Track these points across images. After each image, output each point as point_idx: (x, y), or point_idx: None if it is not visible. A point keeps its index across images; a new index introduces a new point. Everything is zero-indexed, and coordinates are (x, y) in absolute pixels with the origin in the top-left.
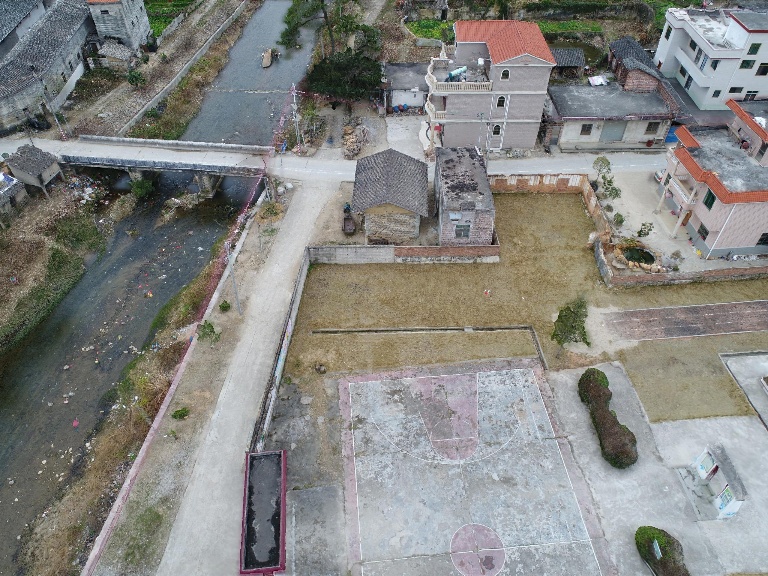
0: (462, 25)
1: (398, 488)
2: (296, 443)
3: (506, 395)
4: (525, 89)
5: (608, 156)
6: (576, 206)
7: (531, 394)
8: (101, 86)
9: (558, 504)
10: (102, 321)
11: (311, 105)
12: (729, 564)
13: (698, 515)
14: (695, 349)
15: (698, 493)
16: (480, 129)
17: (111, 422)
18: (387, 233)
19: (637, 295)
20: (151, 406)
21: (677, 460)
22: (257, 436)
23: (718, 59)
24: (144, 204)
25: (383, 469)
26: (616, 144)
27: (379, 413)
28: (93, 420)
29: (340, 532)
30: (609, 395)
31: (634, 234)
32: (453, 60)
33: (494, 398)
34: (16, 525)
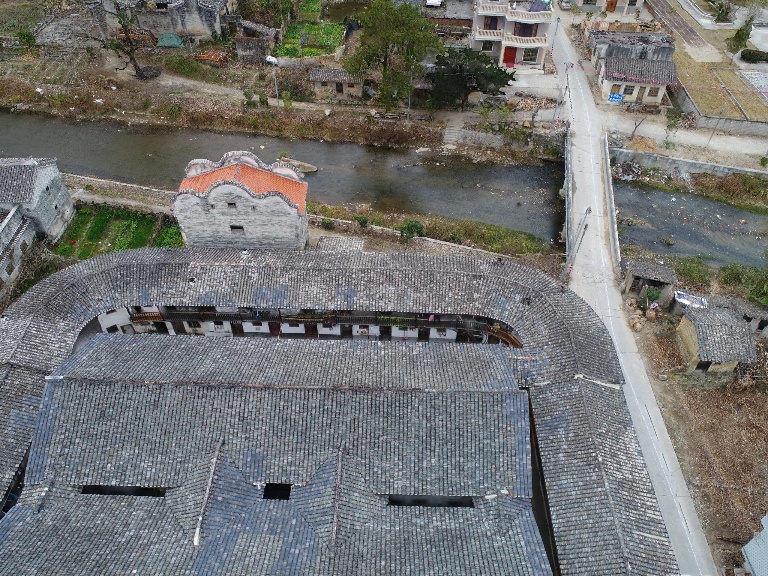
0: None
1: None
2: None
3: None
4: None
5: None
6: None
7: None
8: None
9: None
10: None
11: (485, 110)
12: None
13: None
14: None
15: None
16: None
17: None
18: None
19: None
20: None
21: None
22: None
23: None
24: (621, 239)
25: None
26: None
27: None
28: None
29: None
30: None
31: None
32: None
33: None
34: None
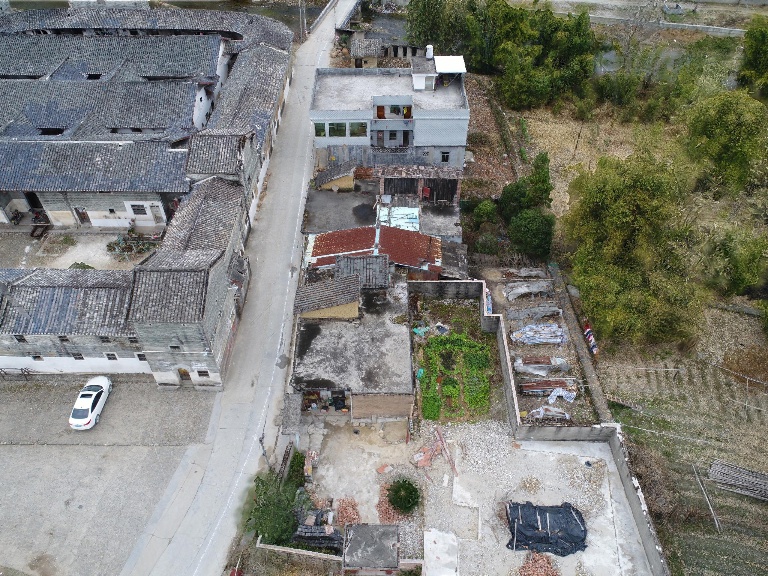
0: None
1: None
2: None
3: None
4: None
5: None
6: None
7: None
8: None
9: None
10: None
11: None
12: None
13: None
14: None
15: None
16: None
17: None
18: None
19: None
20: None
21: None
22: None
23: None
24: (365, 37)
25: None
26: None
27: None
28: None
29: None
30: None
31: None
32: None
33: None
34: None
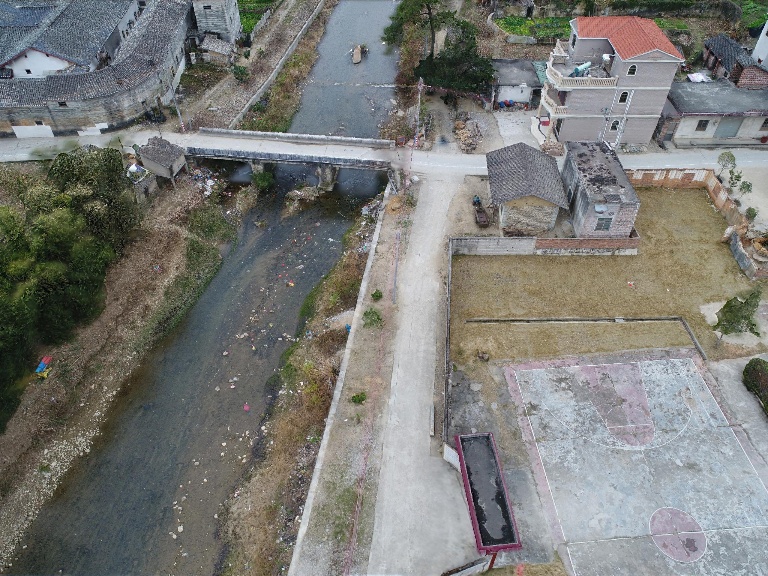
0: (583, 21)
1: (586, 472)
2: (476, 428)
3: (672, 384)
4: (649, 85)
5: None
6: (702, 201)
7: (696, 383)
8: (205, 80)
9: (747, 489)
10: (250, 309)
11: (420, 100)
12: None
13: None
14: None
15: None
16: None
17: (281, 406)
18: (522, 225)
19: None
20: (323, 391)
21: None
22: (447, 420)
23: None
24: (266, 196)
25: (567, 454)
26: (730, 140)
27: (550, 400)
28: (263, 404)
29: (538, 514)
30: None
31: (767, 228)
32: (569, 56)
33: (660, 387)
34: (210, 504)
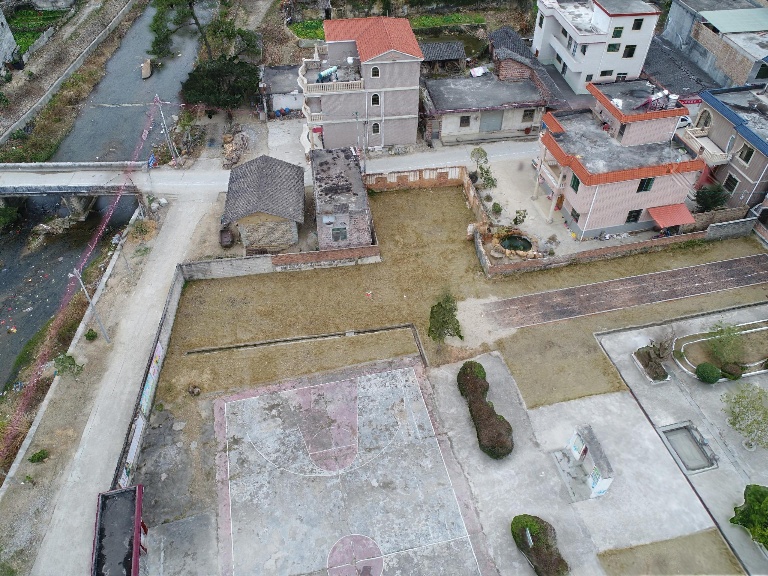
0: (330, 24)
1: (274, 507)
2: (167, 473)
3: (386, 397)
4: (397, 85)
5: (488, 146)
6: (457, 198)
7: (412, 393)
8: None
9: (437, 503)
10: None
11: (187, 115)
12: (601, 542)
13: (573, 497)
14: (571, 331)
15: (573, 474)
16: (357, 128)
17: None
18: (265, 242)
19: (516, 282)
20: (9, 451)
21: (553, 444)
22: (118, 472)
23: (585, 44)
24: (9, 233)
25: (259, 489)
26: (496, 134)
27: (256, 431)
28: None
29: (212, 562)
30: (486, 386)
31: (512, 222)
32: (327, 60)
33: (374, 402)
34: None
